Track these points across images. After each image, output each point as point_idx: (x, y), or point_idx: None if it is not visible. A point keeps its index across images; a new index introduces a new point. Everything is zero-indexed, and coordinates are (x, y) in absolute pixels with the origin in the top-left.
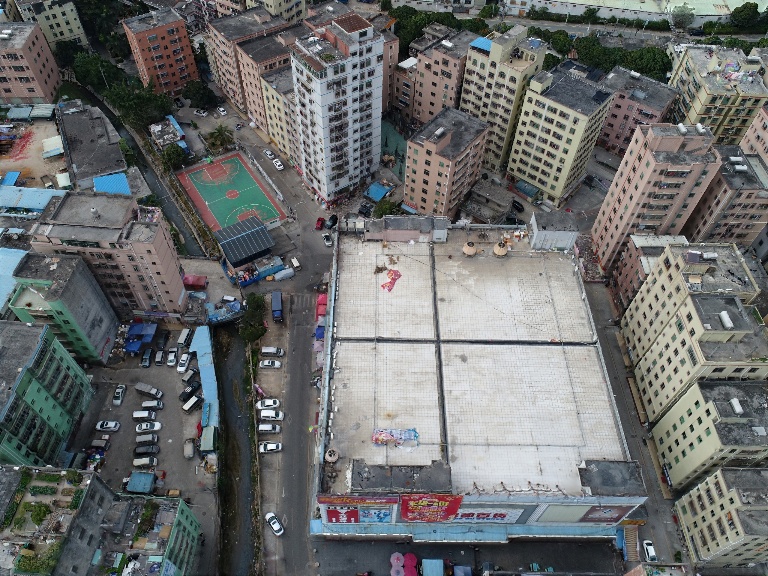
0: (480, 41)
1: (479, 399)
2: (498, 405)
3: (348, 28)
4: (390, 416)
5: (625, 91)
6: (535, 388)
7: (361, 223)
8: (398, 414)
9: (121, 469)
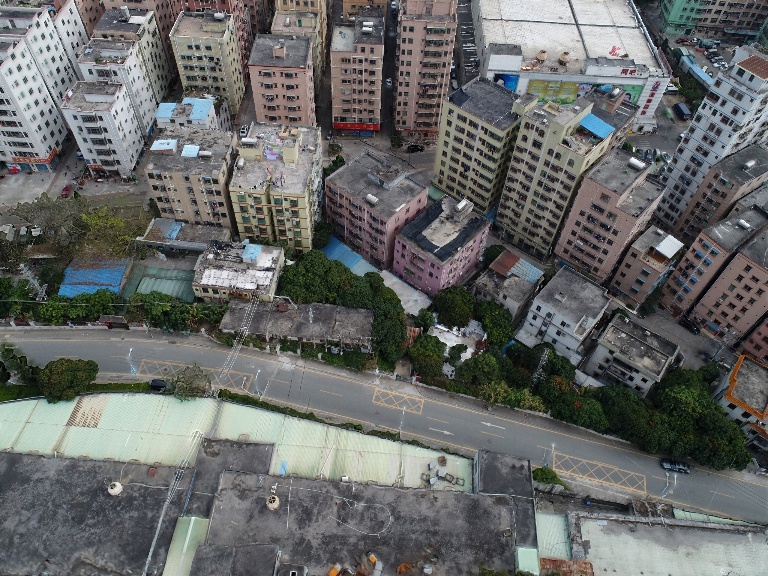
0: (603, 131)
1: (551, 4)
2: (540, 2)
3: (761, 61)
4: (597, 2)
5: (400, 167)
6: (520, 6)
7: (652, 69)
8: (593, 2)
9: (721, 54)
